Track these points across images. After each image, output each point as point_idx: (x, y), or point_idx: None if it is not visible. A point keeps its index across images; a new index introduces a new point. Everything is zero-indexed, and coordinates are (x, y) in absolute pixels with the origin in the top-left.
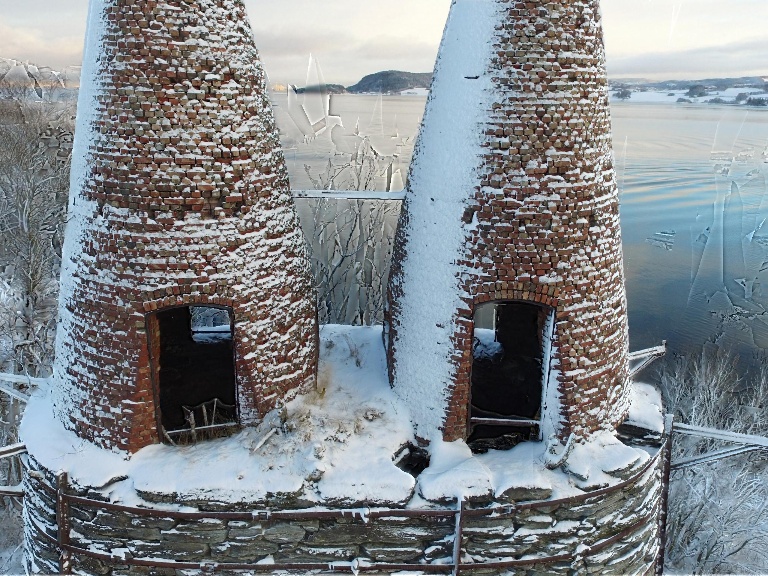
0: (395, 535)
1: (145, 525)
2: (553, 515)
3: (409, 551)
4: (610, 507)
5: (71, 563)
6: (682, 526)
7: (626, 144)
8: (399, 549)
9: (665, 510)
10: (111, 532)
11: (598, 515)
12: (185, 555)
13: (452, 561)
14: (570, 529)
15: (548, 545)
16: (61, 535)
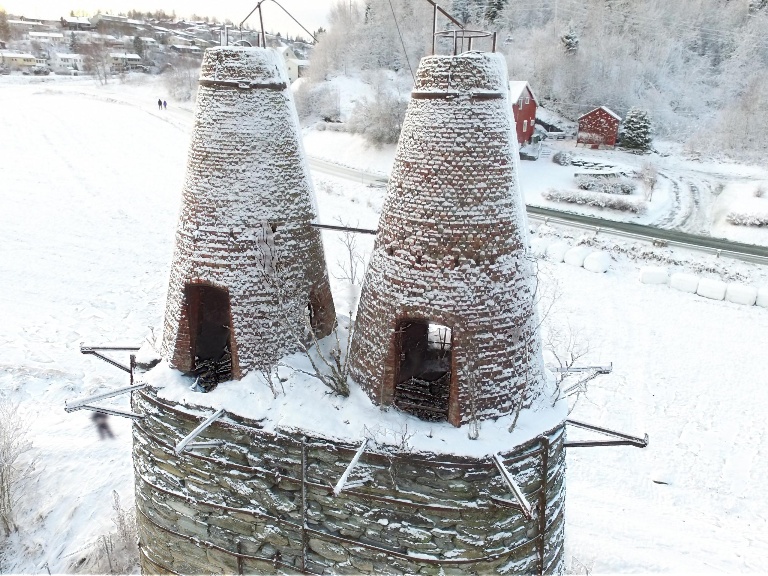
0: None
1: None
2: None
3: None
4: None
5: None
6: None
7: None
8: None
9: None
10: None
11: None
12: None
13: None
14: None
15: None
16: None
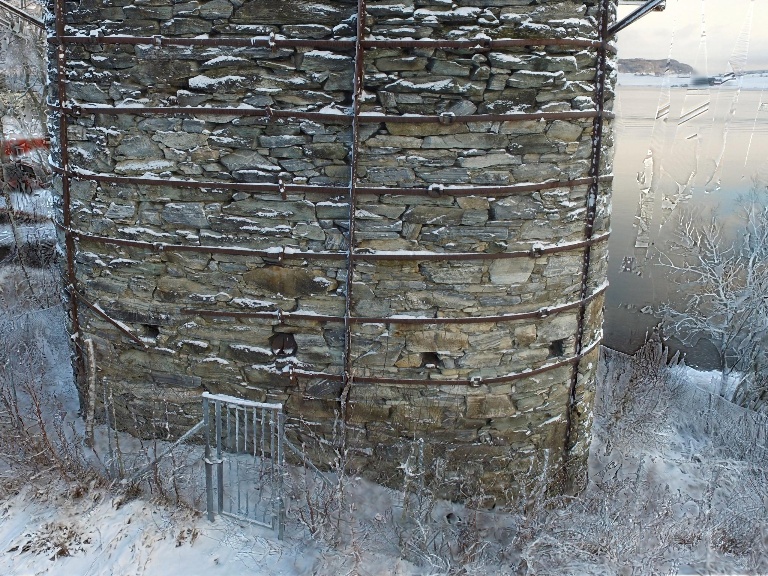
0: (306, 9)
1: (112, 3)
2: (455, 1)
3: (319, 27)
4: (519, 8)
5: (66, 57)
6: (761, 380)
7: (753, 4)
8: (310, 25)
9: (603, 69)
10: (90, 16)
11: (503, 10)
12: (140, 30)
13: (356, 38)
14: (470, 13)
15: (449, 32)
16: (58, 25)
